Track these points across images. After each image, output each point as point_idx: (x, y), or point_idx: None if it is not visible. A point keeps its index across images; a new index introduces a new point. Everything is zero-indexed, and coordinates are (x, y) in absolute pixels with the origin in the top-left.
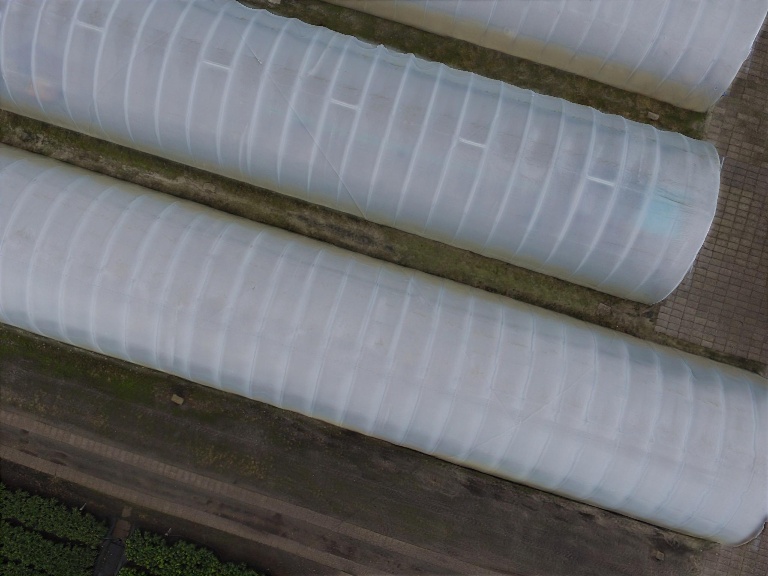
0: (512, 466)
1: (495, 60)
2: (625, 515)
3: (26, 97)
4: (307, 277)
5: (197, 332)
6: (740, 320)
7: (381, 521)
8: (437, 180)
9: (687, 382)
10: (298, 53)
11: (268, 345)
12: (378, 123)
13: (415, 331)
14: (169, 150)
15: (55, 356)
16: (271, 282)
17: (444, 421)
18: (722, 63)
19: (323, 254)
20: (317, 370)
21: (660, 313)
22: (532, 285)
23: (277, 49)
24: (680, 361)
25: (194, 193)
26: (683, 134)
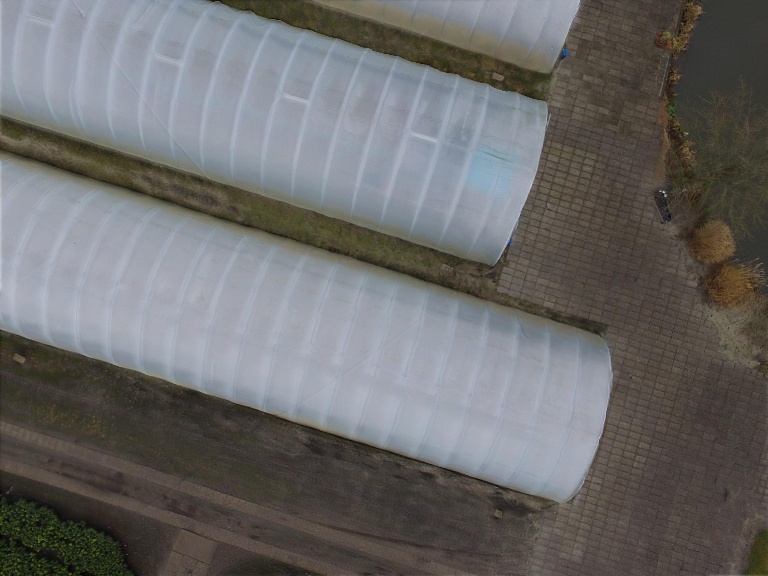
0: (340, 422)
1: (340, 19)
2: (463, 473)
3: None
4: (132, 232)
5: (19, 286)
6: (582, 281)
7: (222, 479)
8: (263, 136)
9: (513, 339)
10: (123, 7)
11: (89, 299)
12: (201, 77)
13: (237, 286)
14: (7, 107)
15: None
16: (94, 237)
17: (267, 376)
18: (553, 21)
19: (156, 211)
20: (139, 325)
21: (503, 274)
22: (375, 245)
23: (101, 2)
24: (512, 319)
25: (37, 152)
26: (528, 95)
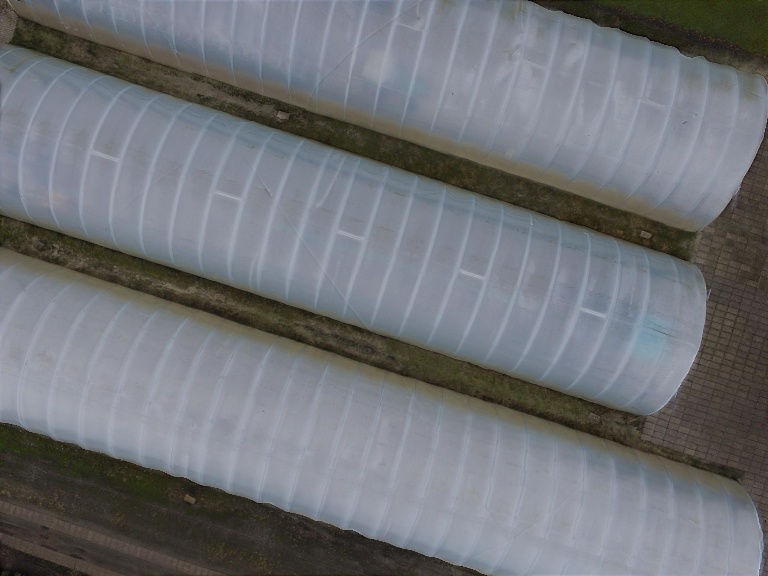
0: (504, 573)
1: (496, 178)
2: None
3: (42, 211)
4: (314, 398)
5: (210, 451)
6: (721, 430)
7: None
8: (439, 308)
9: (669, 498)
10: (307, 185)
11: (277, 464)
12: (383, 255)
13: (416, 452)
14: (181, 265)
15: (73, 457)
16: (280, 404)
17: (441, 535)
18: (712, 196)
19: (329, 371)
20: (323, 488)
21: (646, 422)
22: (527, 395)
23: (287, 181)
24: (663, 475)
25: (205, 303)
26: (674, 252)
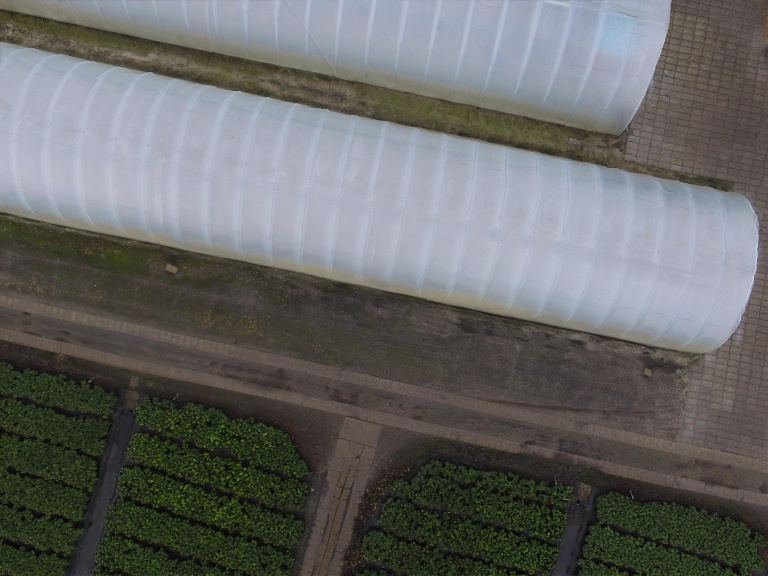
0: (498, 290)
1: None
2: (611, 336)
3: None
4: (283, 124)
5: (182, 185)
6: (705, 142)
7: (379, 365)
8: (400, 18)
9: (657, 192)
10: None
11: (252, 190)
12: None
13: (392, 164)
14: (138, 25)
15: (48, 239)
16: (249, 130)
17: (428, 248)
18: None
19: (297, 107)
20: (302, 210)
21: (628, 142)
22: (503, 127)
23: None
24: (650, 178)
25: (167, 68)
26: None
